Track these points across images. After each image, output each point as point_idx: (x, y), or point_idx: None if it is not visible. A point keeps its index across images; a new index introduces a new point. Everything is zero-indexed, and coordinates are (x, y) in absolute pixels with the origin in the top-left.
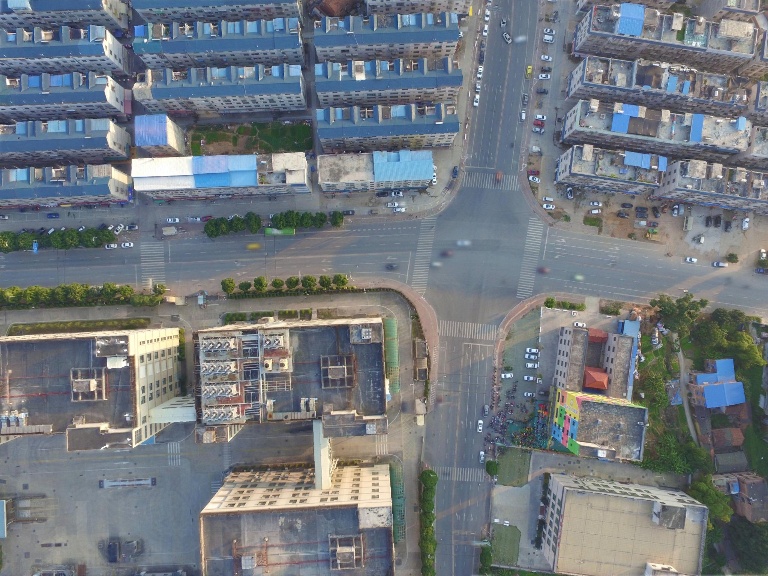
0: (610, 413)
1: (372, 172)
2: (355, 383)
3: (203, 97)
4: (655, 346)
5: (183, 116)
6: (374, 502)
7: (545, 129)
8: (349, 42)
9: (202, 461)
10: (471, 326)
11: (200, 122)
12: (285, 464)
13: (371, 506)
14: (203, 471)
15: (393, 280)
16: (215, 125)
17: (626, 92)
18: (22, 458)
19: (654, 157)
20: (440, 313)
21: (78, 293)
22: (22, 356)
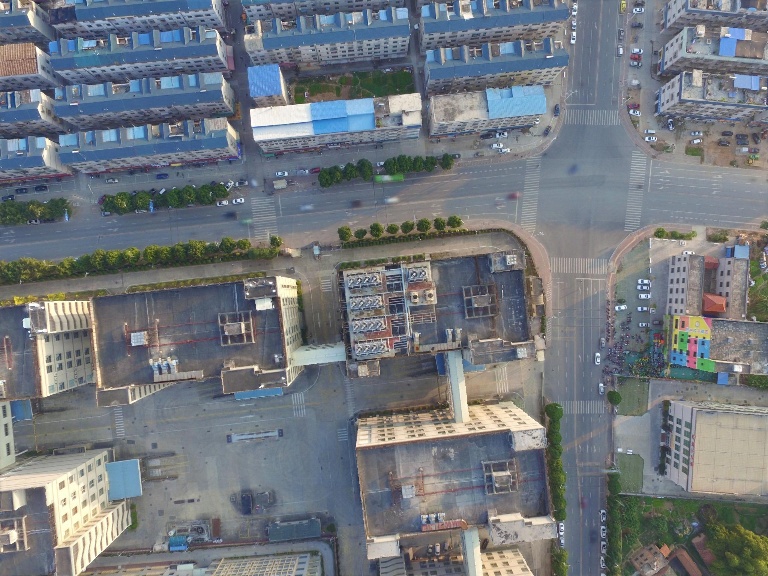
0: (739, 330)
1: (486, 110)
2: (497, 312)
3: (313, 45)
4: (763, 270)
5: (286, 69)
6: (525, 426)
7: (642, 63)
8: None
9: (327, 410)
10: (582, 261)
11: (302, 75)
12: (409, 408)
13: (525, 429)
14: (328, 420)
15: (502, 220)
16: (317, 77)
17: (728, 17)
18: (149, 418)
19: (763, 78)
20: (551, 250)
21: (198, 249)
22: (168, 305)
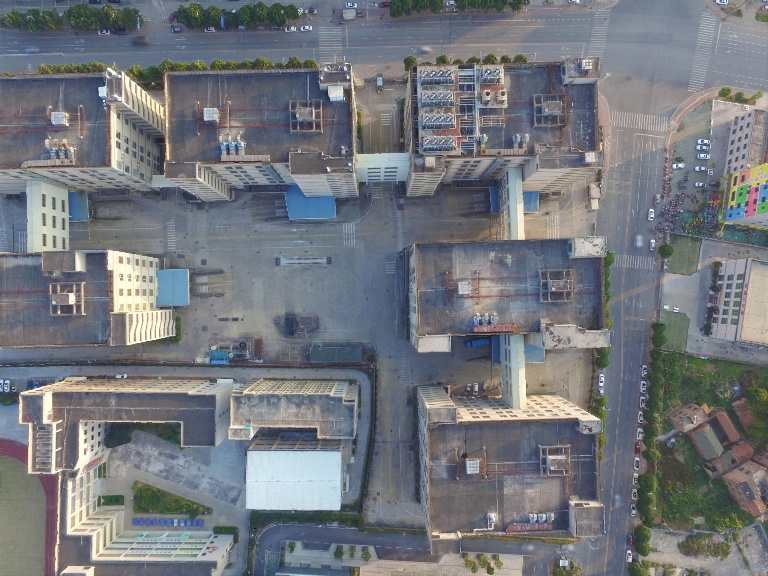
0: None
1: None
2: None
3: None
4: None
5: None
6: None
7: None
8: None
9: (377, 242)
10: (643, 117)
11: None
12: None
13: None
14: (377, 251)
15: None
16: None
17: None
18: (201, 234)
19: None
20: (612, 104)
21: (265, 65)
22: (240, 89)
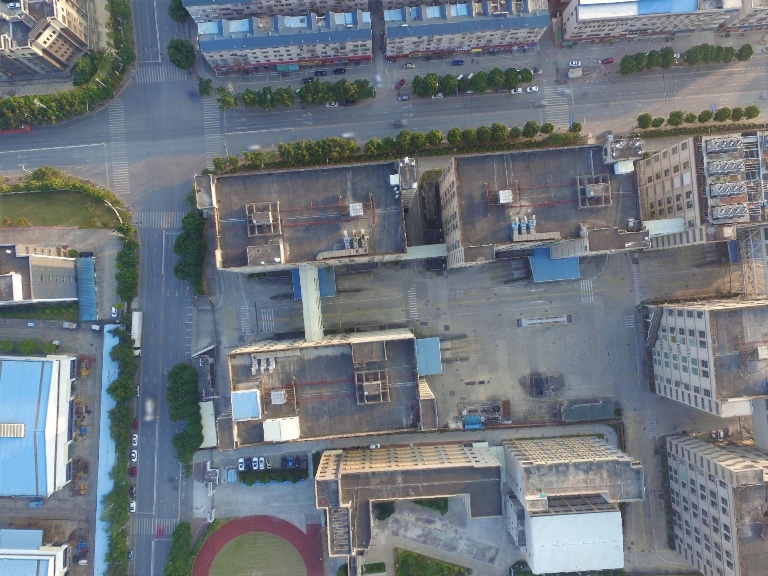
0: None
1: None
2: None
3: None
4: None
5: None
6: None
7: None
8: None
9: (614, 297)
10: None
11: None
12: (694, 297)
13: None
14: (616, 307)
15: None
16: None
17: None
18: (442, 301)
19: None
20: None
21: (506, 131)
22: (526, 167)
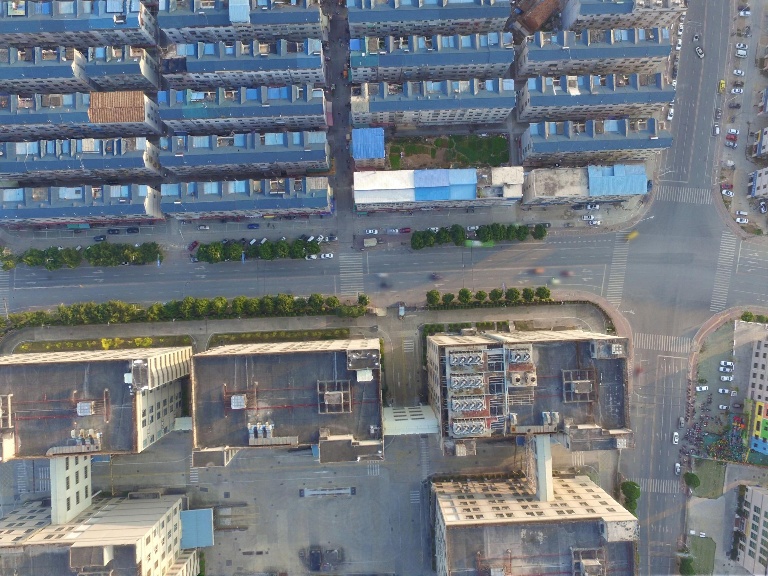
0: None
1: (587, 186)
2: (595, 397)
3: (417, 111)
4: None
5: (384, 128)
6: (616, 515)
7: (737, 143)
8: (562, 57)
9: (401, 471)
10: (665, 339)
11: (398, 134)
12: (483, 474)
13: (618, 520)
14: (402, 481)
15: (588, 292)
16: (413, 137)
17: None
18: (223, 467)
19: None
20: (635, 326)
21: (288, 304)
22: (267, 368)
